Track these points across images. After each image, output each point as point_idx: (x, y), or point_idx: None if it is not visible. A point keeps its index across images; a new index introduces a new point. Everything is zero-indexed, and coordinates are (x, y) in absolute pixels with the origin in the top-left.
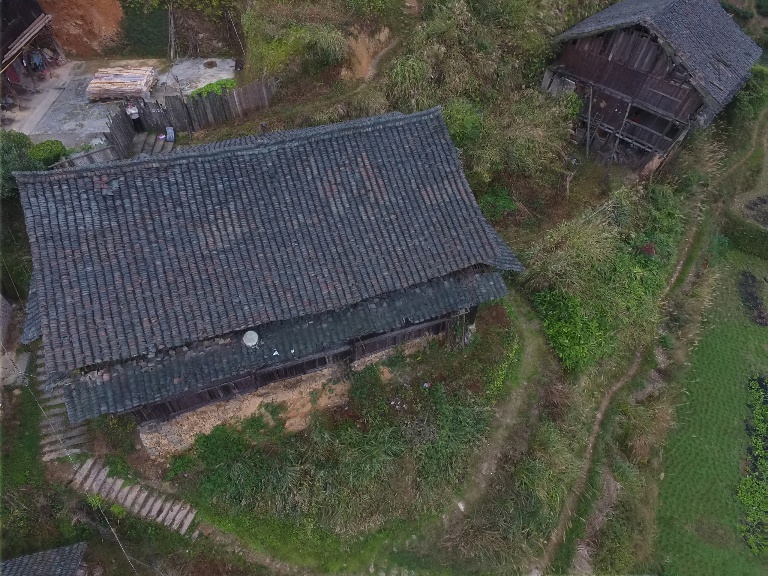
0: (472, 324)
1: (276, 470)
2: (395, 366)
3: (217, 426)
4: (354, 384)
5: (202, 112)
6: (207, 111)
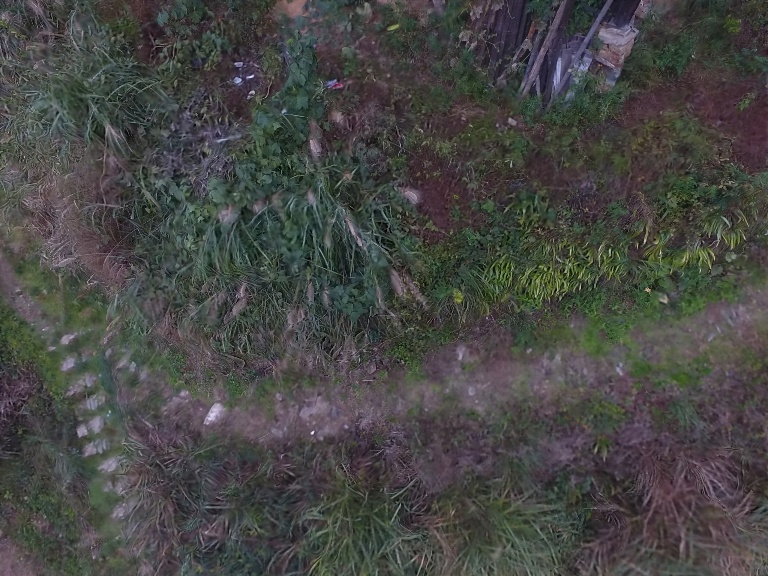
0: (620, 20)
1: (3, 16)
2: None
3: None
4: None
5: None
6: None
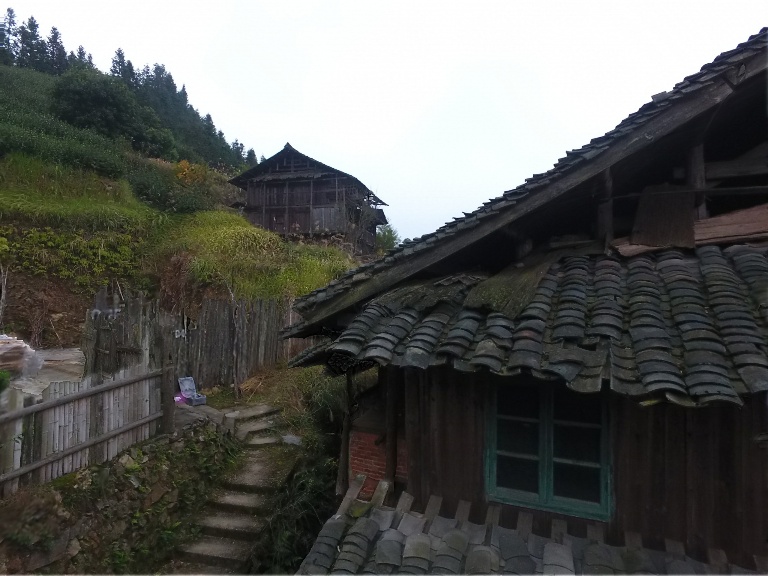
0: None
1: None
2: None
3: None
4: None
5: (254, 340)
6: (260, 339)
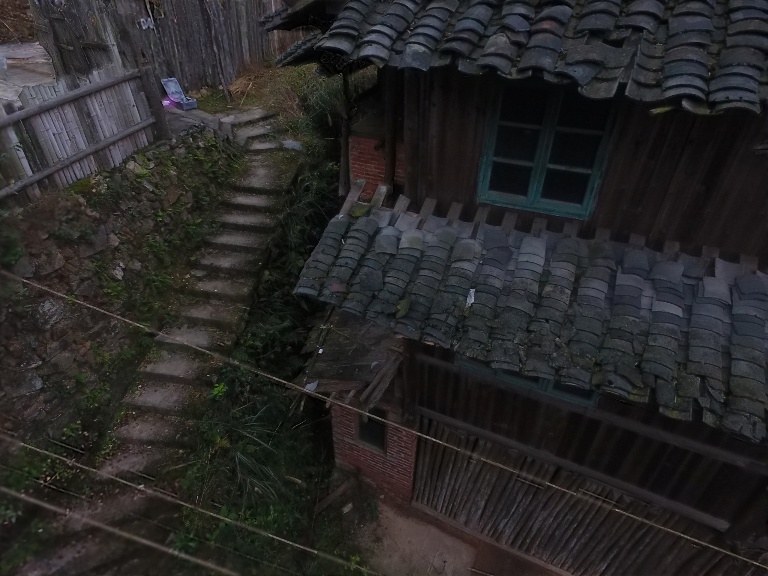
0: None
1: None
2: None
3: None
4: None
5: (234, 31)
6: (240, 30)
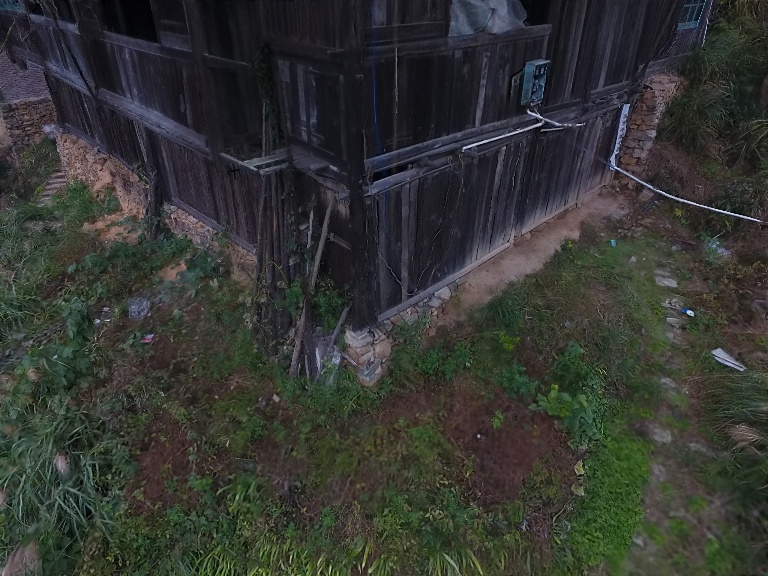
0: (354, 325)
1: None
2: (192, 270)
3: (80, 180)
4: (139, 238)
5: None
6: None
